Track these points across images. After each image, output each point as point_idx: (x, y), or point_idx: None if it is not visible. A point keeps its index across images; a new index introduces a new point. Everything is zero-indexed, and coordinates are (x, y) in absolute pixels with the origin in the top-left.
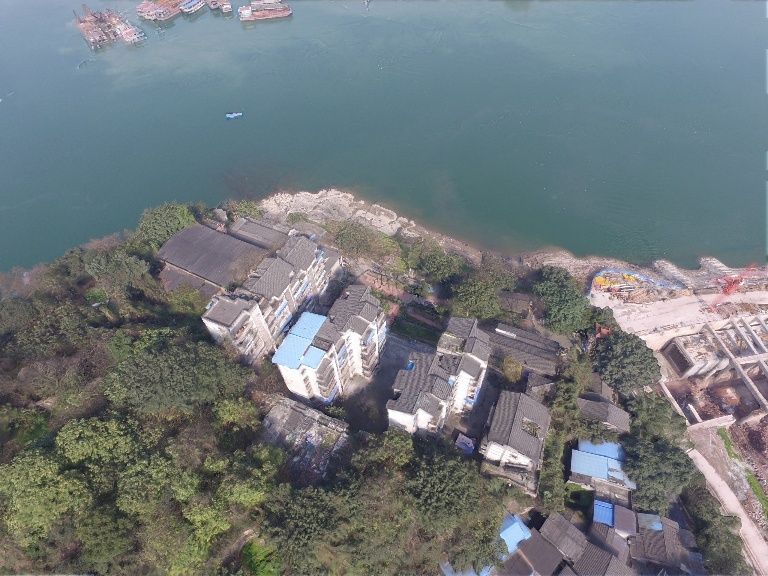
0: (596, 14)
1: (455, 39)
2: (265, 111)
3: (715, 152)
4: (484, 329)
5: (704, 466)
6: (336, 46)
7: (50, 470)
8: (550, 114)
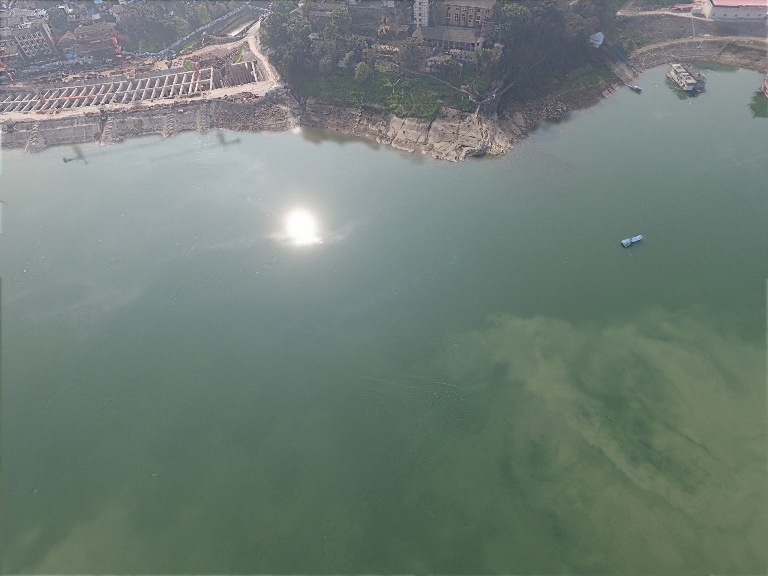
0: None
1: None
2: (601, 263)
3: (54, 230)
4: None
5: (256, 52)
6: (580, 447)
7: None
8: (200, 275)
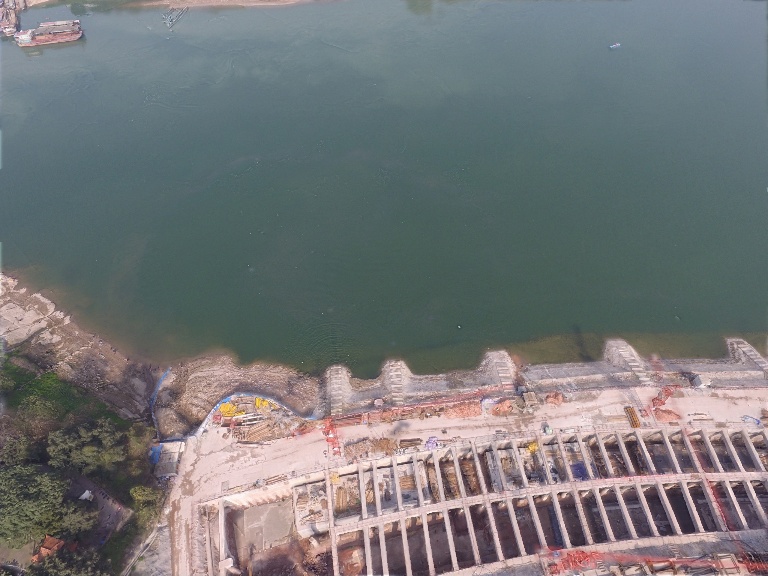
0: (422, 32)
1: (253, 66)
2: None
3: (470, 210)
4: None
5: None
6: (103, 79)
7: None
8: (305, 163)
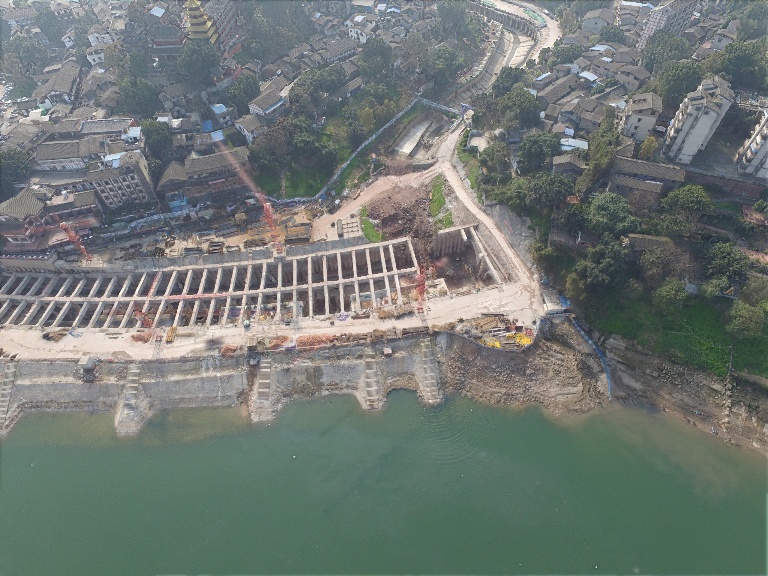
0: None
1: None
2: None
3: None
4: None
5: (471, 205)
6: None
7: None
8: None
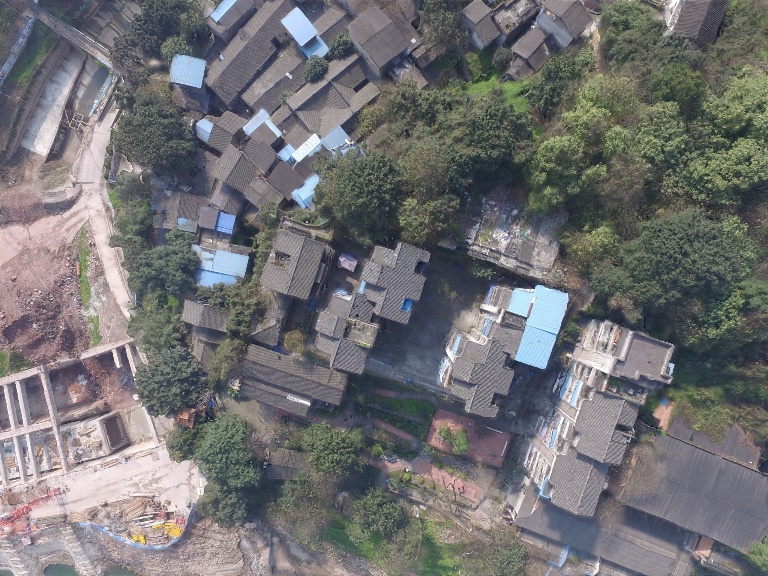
0: None
1: None
2: None
3: None
4: (324, 419)
5: (125, 303)
6: None
7: (762, 118)
8: None
